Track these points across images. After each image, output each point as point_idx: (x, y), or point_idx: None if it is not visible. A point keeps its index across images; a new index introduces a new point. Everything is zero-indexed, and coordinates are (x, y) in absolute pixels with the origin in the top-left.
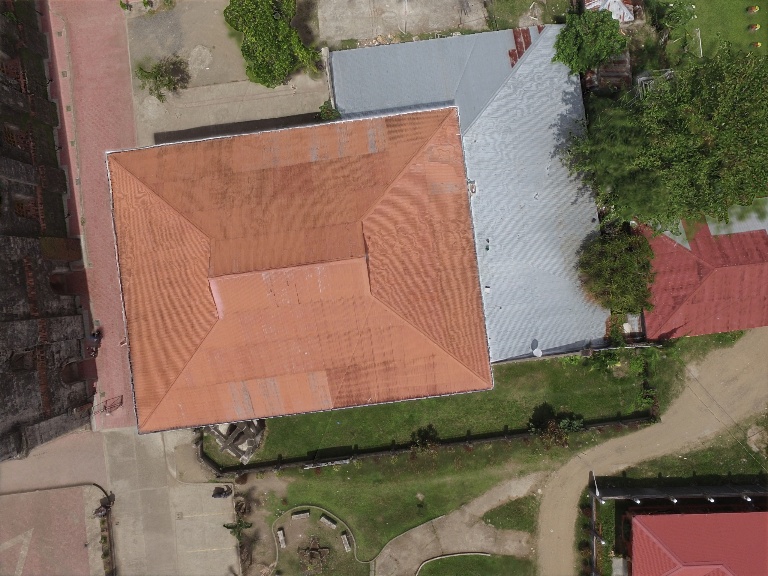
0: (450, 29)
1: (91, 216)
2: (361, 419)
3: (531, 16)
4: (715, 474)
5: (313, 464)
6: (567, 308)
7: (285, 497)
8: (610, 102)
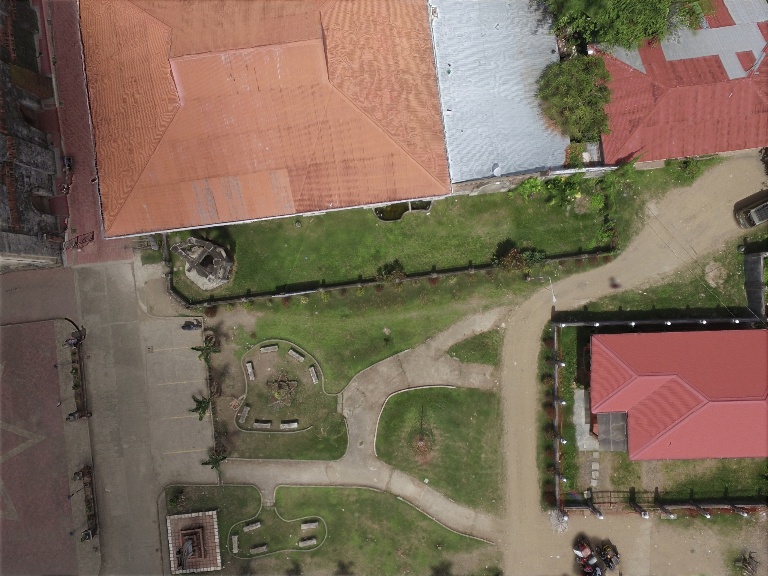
0: None
1: (63, 56)
2: (328, 254)
3: None
4: (674, 308)
5: (281, 293)
6: (527, 134)
7: (254, 331)
8: None
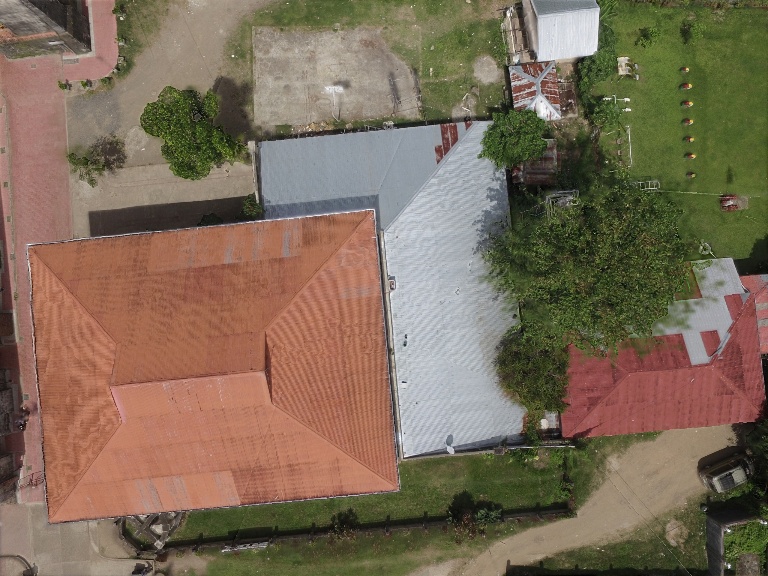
0: (383, 118)
1: (24, 291)
2: None
3: (464, 107)
4: (632, 568)
5: (231, 546)
6: (484, 404)
7: (205, 575)
8: (535, 199)
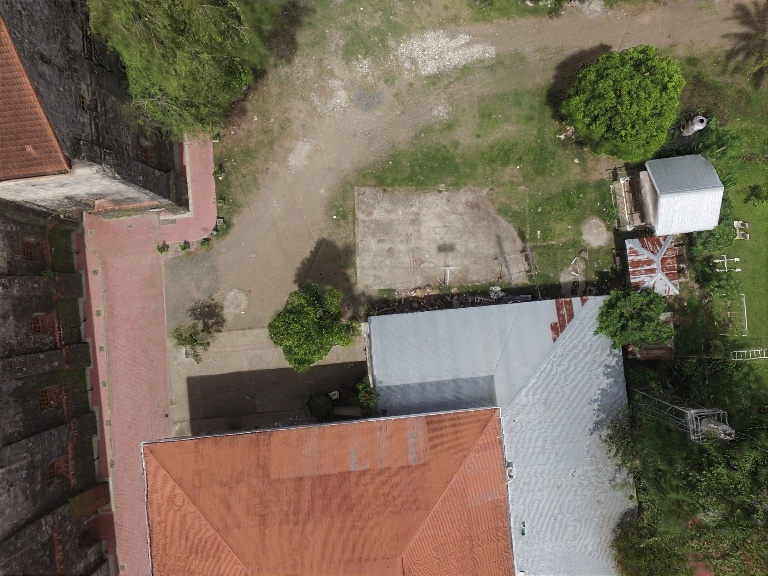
0: (490, 282)
1: (120, 458)
2: None
3: (572, 271)
4: None
5: None
6: None
7: None
8: (652, 376)
